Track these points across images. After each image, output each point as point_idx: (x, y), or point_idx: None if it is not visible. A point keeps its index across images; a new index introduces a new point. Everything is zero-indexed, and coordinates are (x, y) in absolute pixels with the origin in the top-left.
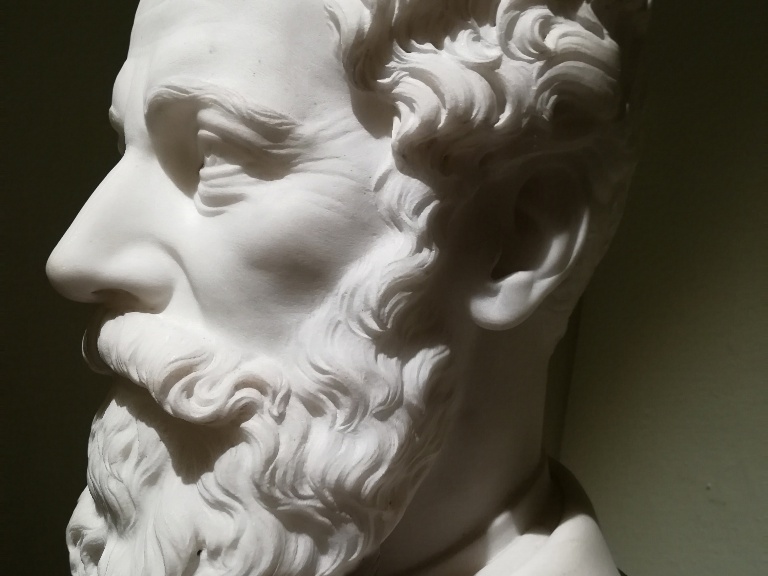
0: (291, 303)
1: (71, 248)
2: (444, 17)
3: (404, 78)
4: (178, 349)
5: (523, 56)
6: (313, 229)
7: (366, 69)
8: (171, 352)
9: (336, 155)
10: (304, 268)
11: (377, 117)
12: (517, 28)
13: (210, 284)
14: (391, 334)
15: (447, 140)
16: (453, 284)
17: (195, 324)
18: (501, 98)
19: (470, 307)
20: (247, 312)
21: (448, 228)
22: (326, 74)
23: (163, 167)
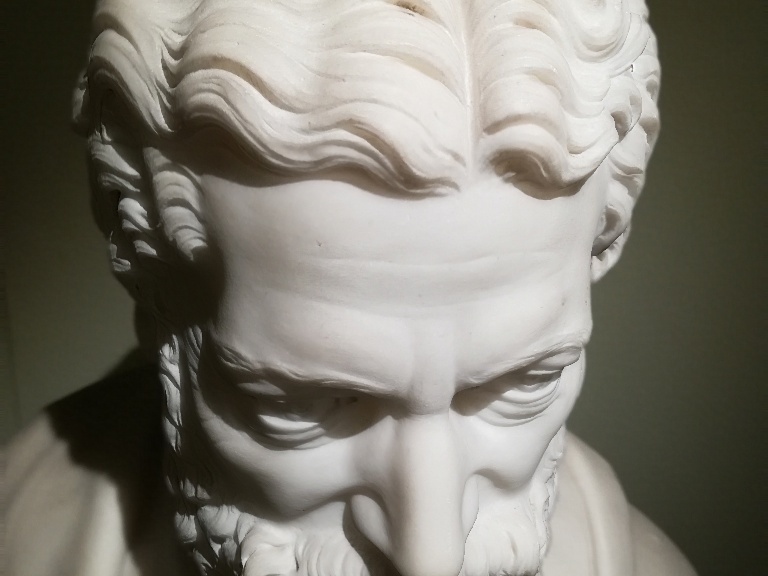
0: None
1: (455, 550)
2: None
3: None
4: (533, 536)
5: None
6: None
7: None
8: (534, 543)
9: None
10: None
11: None
12: None
13: None
14: None
15: None
16: None
17: (498, 504)
18: None
19: None
20: None
21: None
22: None
23: (455, 409)
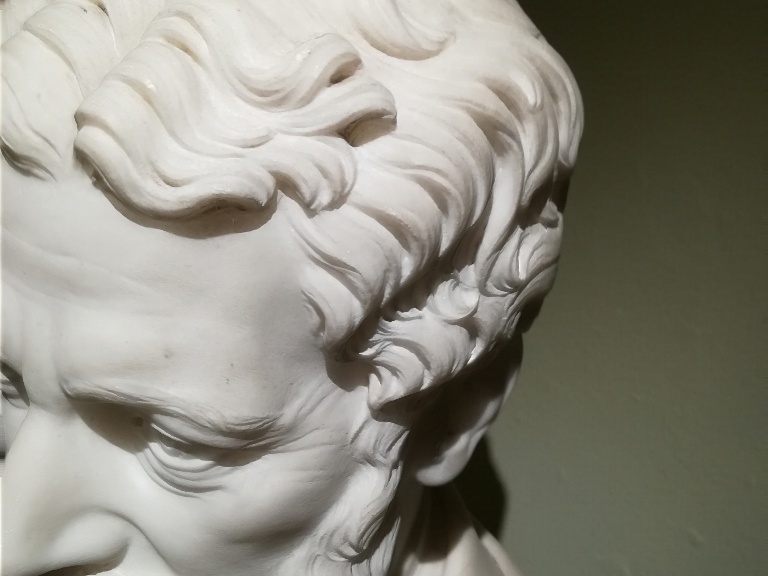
0: (271, 554)
1: (7, 552)
2: (427, 274)
3: (387, 347)
4: None
5: (498, 292)
6: (298, 503)
7: (348, 345)
8: None
9: (315, 427)
10: (287, 531)
11: (351, 372)
12: (496, 268)
13: (186, 560)
14: (365, 549)
15: (425, 390)
16: (406, 469)
17: None
18: (474, 334)
19: (416, 475)
20: (227, 572)
21: (409, 437)
22: (301, 351)
23: (90, 426)
